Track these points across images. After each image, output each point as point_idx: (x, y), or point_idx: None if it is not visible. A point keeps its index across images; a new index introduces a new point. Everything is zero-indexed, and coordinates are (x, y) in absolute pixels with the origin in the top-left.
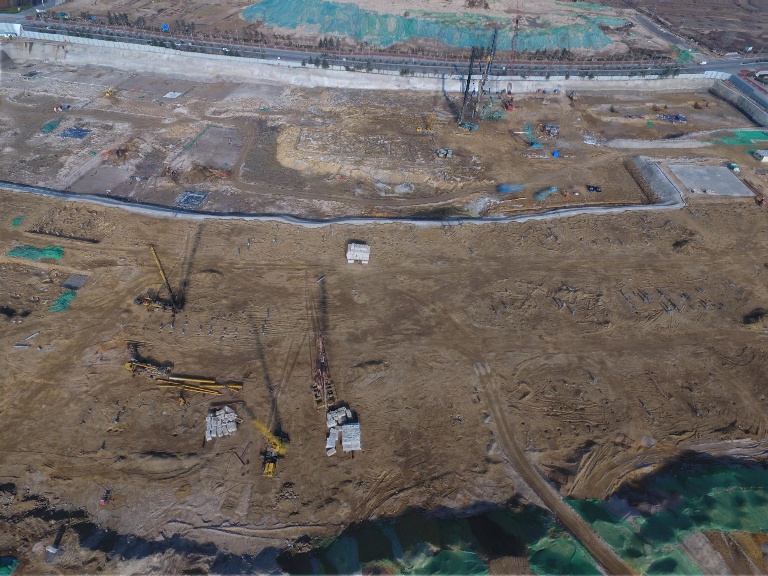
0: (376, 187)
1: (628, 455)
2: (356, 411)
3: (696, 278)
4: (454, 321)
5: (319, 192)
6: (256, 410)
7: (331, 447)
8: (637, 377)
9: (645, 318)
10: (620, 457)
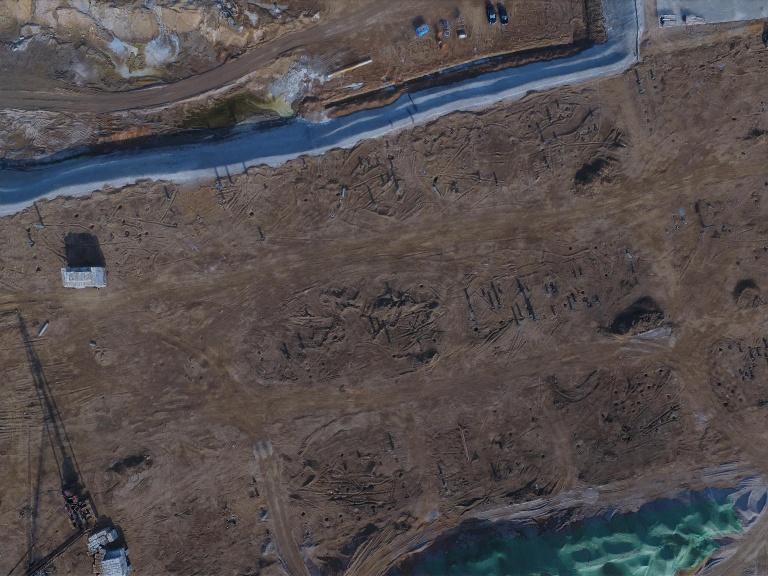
0: (111, 52)
1: (405, 537)
2: (121, 526)
3: (582, 248)
4: (232, 379)
5: (10, 86)
6: (11, 540)
7: (99, 573)
8: (445, 436)
9: (484, 339)
10: (396, 541)
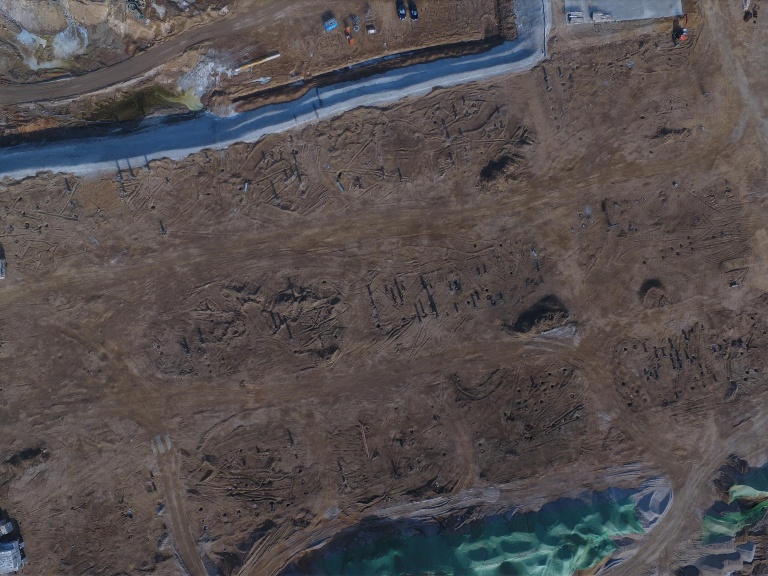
0: (19, 44)
1: (303, 534)
2: (16, 519)
3: (487, 246)
4: (131, 373)
5: None
6: None
7: None
8: (345, 432)
9: (386, 336)
10: (294, 538)
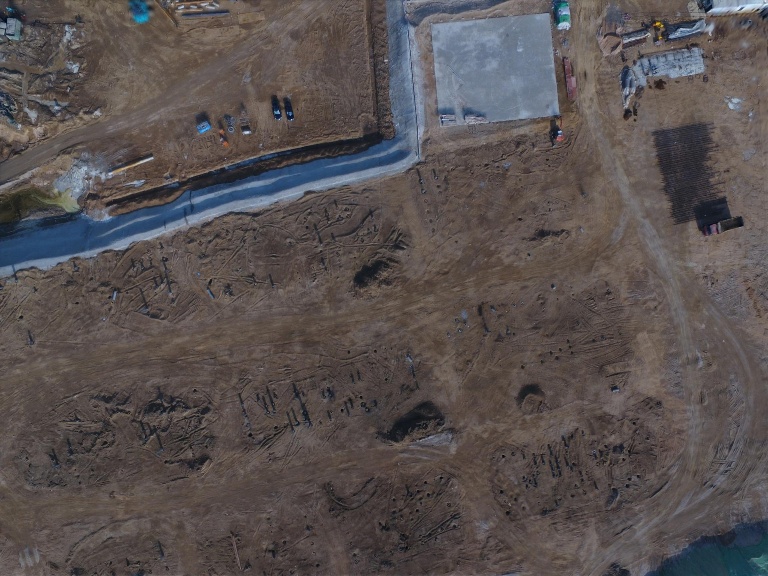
0: None
1: None
2: None
3: (360, 352)
4: None
5: None
6: None
7: None
8: (216, 544)
9: (257, 445)
10: None
